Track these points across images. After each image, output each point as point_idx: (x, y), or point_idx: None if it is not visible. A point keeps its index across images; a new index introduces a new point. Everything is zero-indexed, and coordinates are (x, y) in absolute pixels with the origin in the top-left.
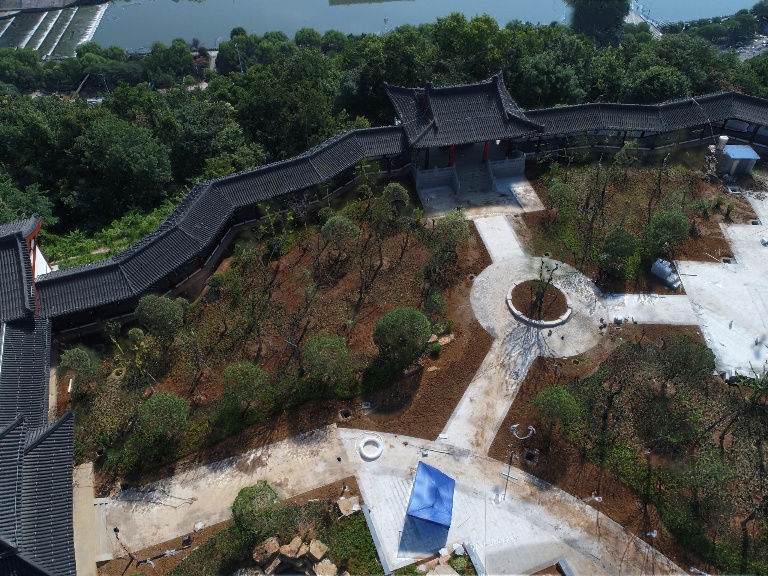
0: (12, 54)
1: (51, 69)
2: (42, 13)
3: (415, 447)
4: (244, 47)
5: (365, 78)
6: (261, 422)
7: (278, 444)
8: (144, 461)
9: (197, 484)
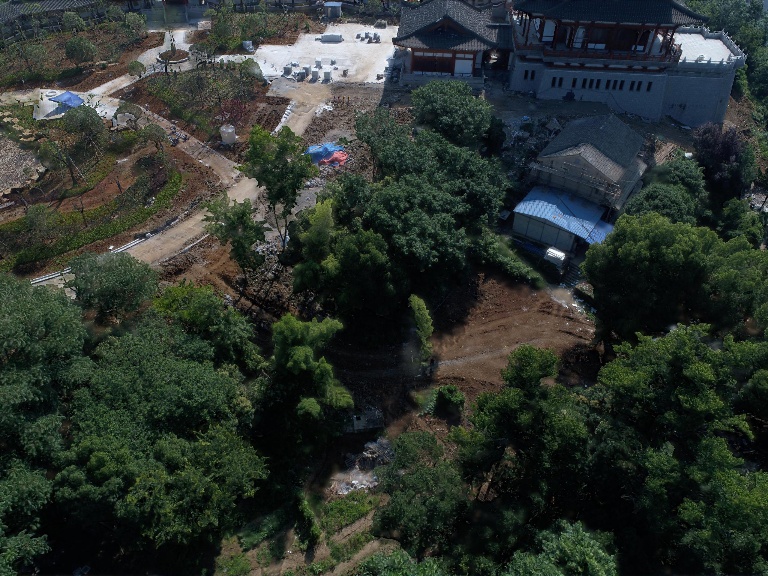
0: None
1: None
2: None
3: None
4: None
5: None
6: (3, 86)
7: (8, 92)
8: None
9: None
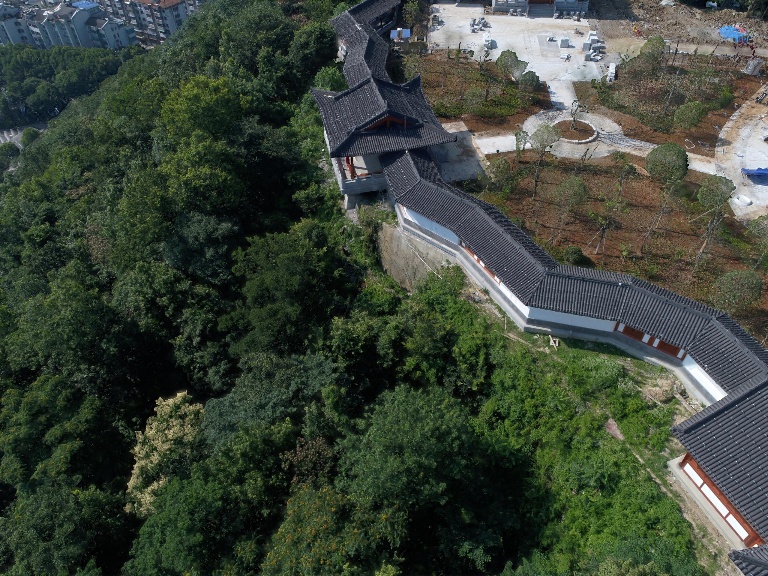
0: None
1: None
2: None
3: None
4: None
5: None
6: None
7: None
8: None
9: None
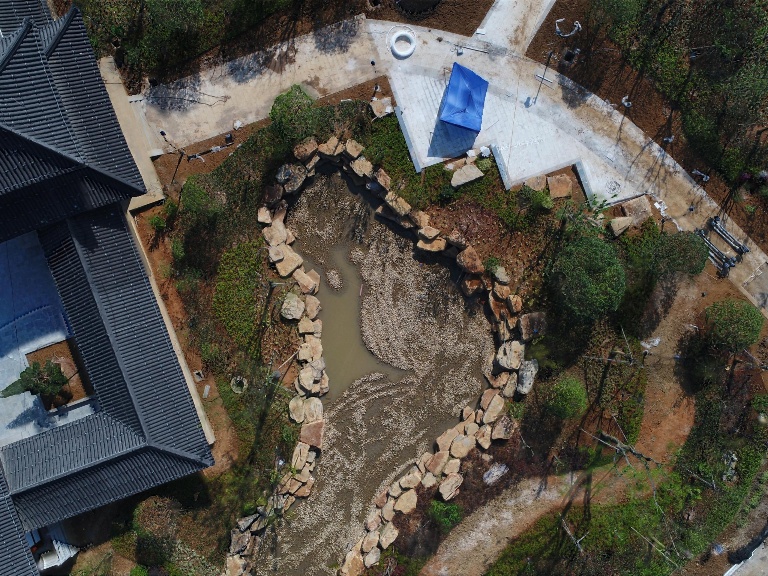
0: None
1: None
2: None
3: (450, 44)
4: None
5: None
6: (282, 11)
7: (304, 38)
8: (166, 55)
9: (227, 81)
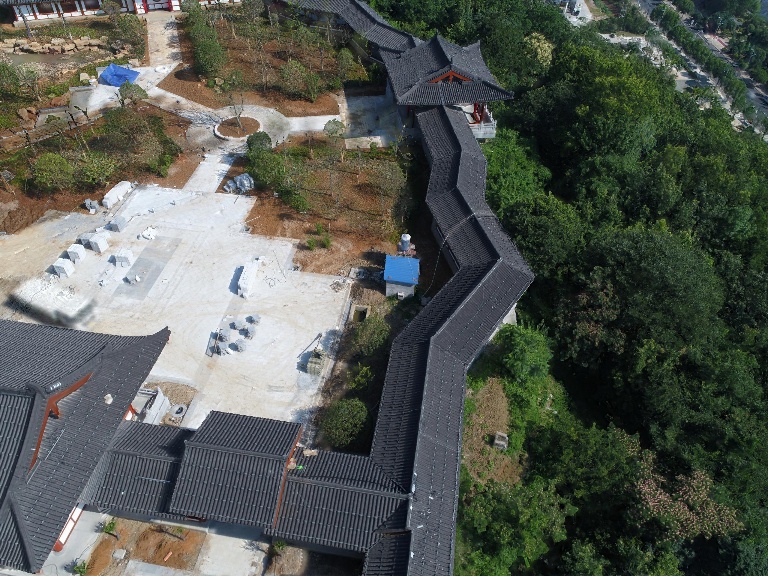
0: None
1: None
2: None
3: None
4: None
5: None
6: None
7: None
8: None
9: None
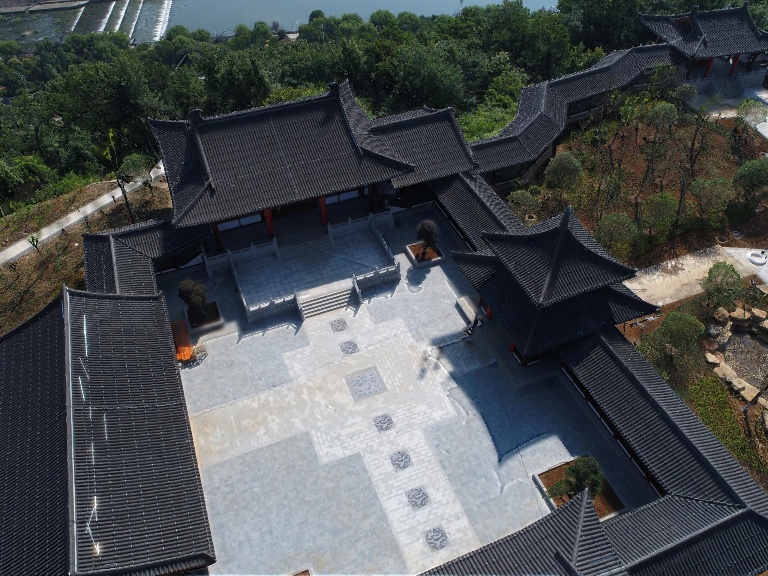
0: (106, 38)
1: (146, 51)
2: (110, 3)
3: None
4: (324, 28)
5: (586, 18)
6: (663, 244)
7: (684, 257)
8: None
9: (640, 281)
